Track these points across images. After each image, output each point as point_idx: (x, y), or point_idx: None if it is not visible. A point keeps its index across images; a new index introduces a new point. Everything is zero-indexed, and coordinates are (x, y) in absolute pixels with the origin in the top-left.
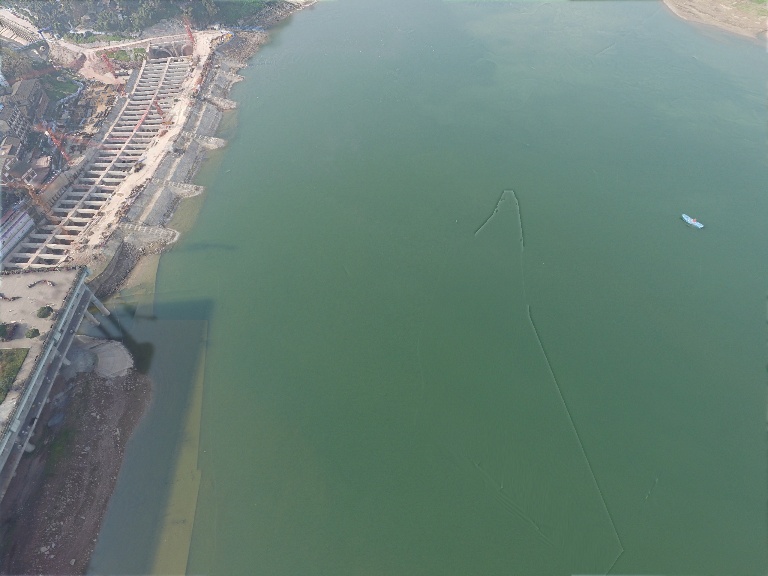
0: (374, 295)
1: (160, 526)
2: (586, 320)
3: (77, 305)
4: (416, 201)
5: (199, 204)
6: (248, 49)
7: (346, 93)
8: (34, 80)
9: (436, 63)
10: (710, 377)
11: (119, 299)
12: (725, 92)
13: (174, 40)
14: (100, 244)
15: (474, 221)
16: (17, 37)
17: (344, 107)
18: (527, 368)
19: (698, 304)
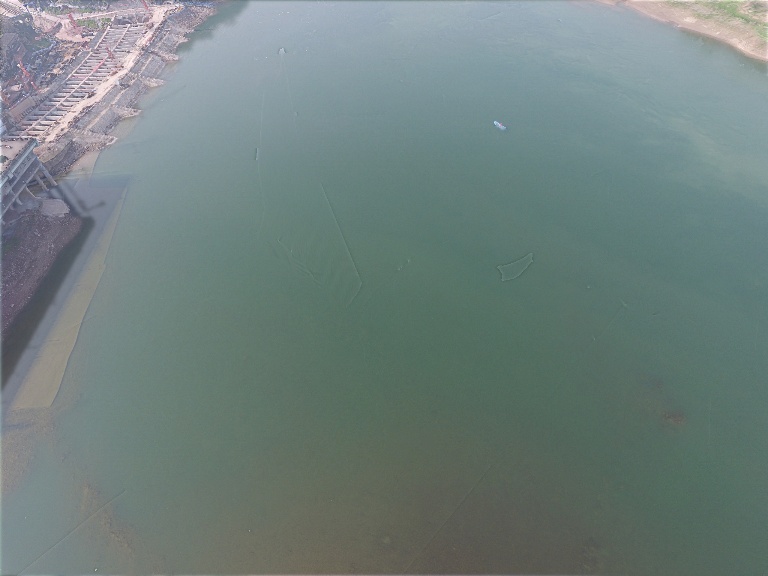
0: (240, 159)
1: (73, 291)
2: (403, 185)
3: (29, 166)
4: (301, 116)
5: (135, 121)
6: (196, 19)
7: (268, 48)
8: (14, 34)
9: (346, 26)
10: (475, 213)
11: (65, 177)
12: (572, 44)
13: (136, 12)
14: (54, 140)
15: (340, 127)
16: (8, 13)
17: (264, 57)
18: (302, 168)
19: (480, 170)
